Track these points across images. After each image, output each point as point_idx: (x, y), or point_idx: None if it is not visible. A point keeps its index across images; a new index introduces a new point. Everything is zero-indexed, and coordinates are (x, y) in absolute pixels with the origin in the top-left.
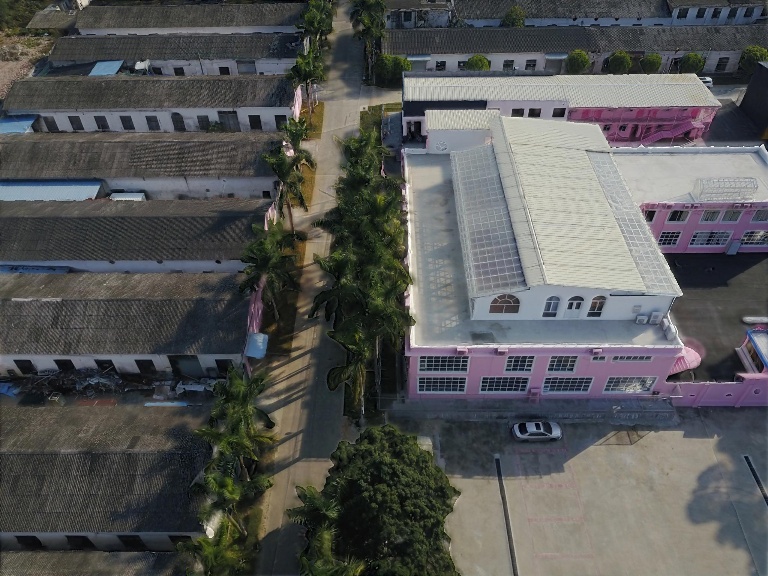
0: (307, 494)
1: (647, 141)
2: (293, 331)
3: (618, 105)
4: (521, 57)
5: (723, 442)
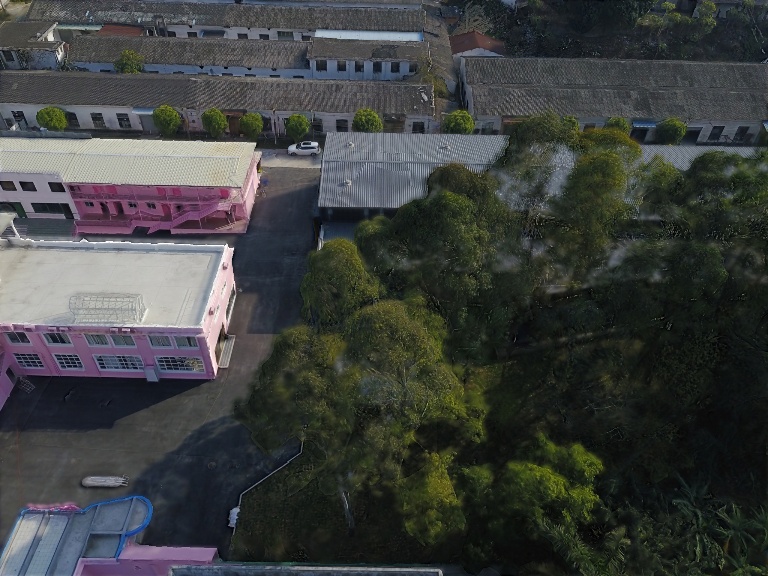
0: None
1: (174, 222)
2: None
3: (122, 181)
4: (108, 110)
5: None
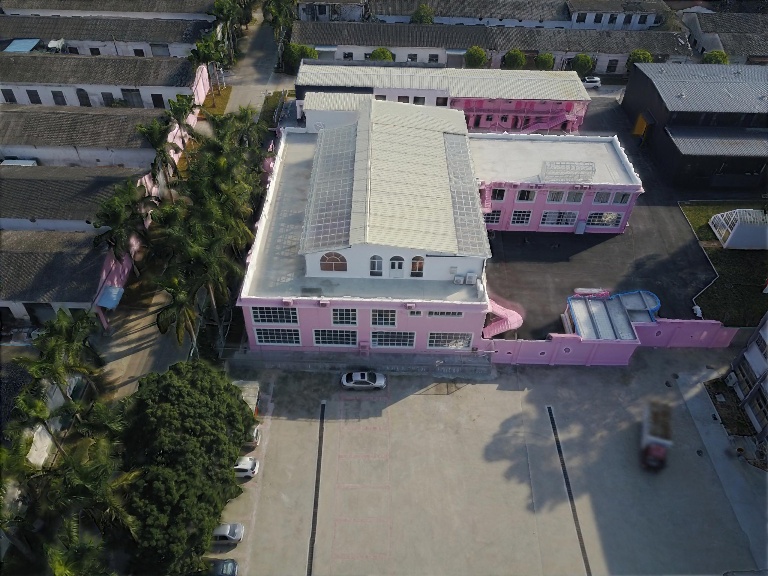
0: (94, 409)
1: (525, 132)
2: (156, 289)
3: (496, 96)
4: (424, 52)
5: (531, 394)
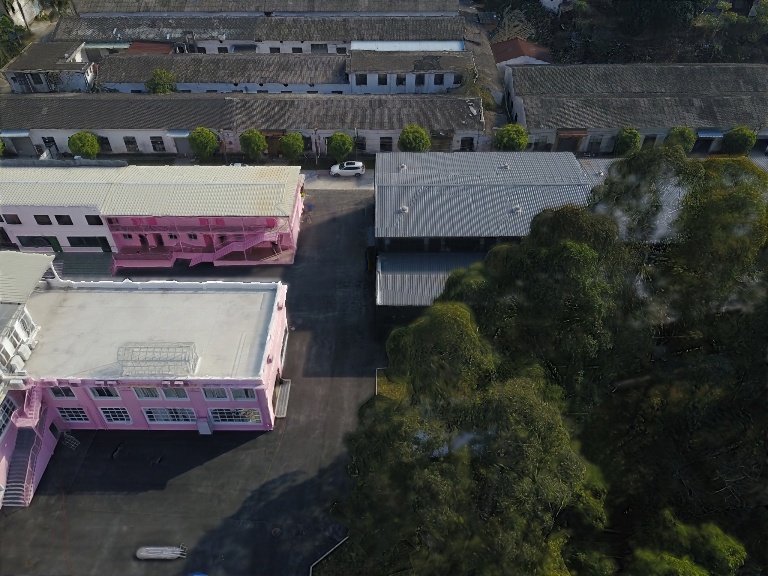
0: None
1: (217, 254)
2: None
3: (162, 213)
4: (142, 133)
5: None
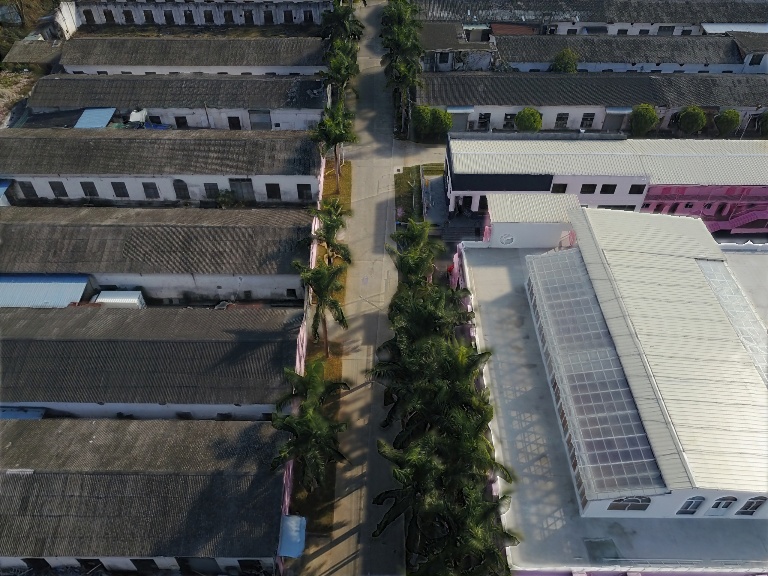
0: None
1: (737, 222)
2: (334, 497)
3: (708, 182)
4: (578, 110)
5: None
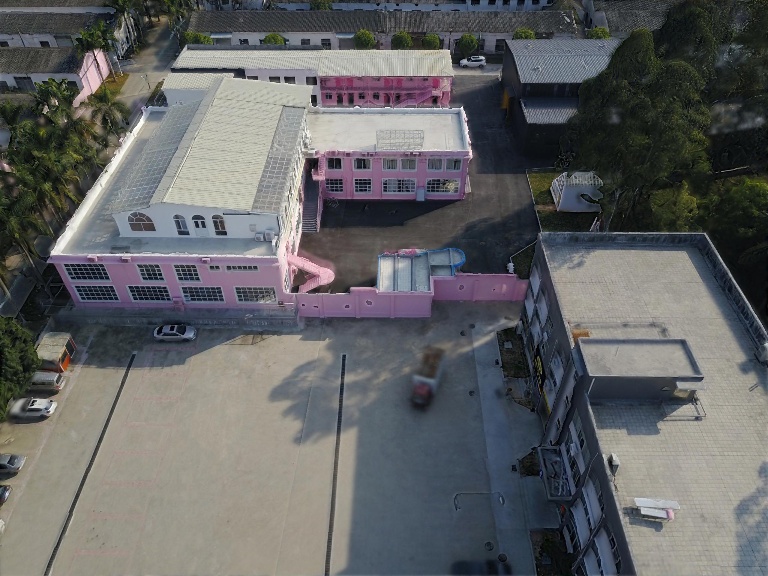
0: None
1: None
2: (5, 255)
3: (362, 74)
4: (316, 36)
5: (331, 344)
